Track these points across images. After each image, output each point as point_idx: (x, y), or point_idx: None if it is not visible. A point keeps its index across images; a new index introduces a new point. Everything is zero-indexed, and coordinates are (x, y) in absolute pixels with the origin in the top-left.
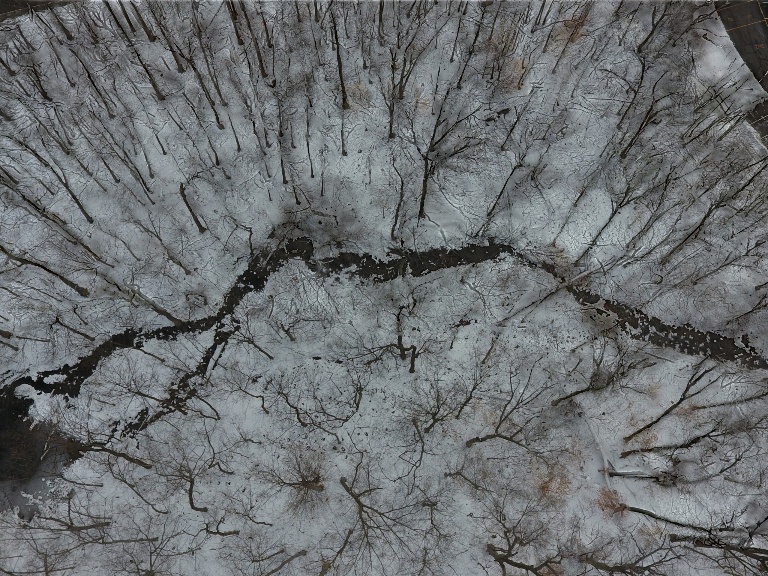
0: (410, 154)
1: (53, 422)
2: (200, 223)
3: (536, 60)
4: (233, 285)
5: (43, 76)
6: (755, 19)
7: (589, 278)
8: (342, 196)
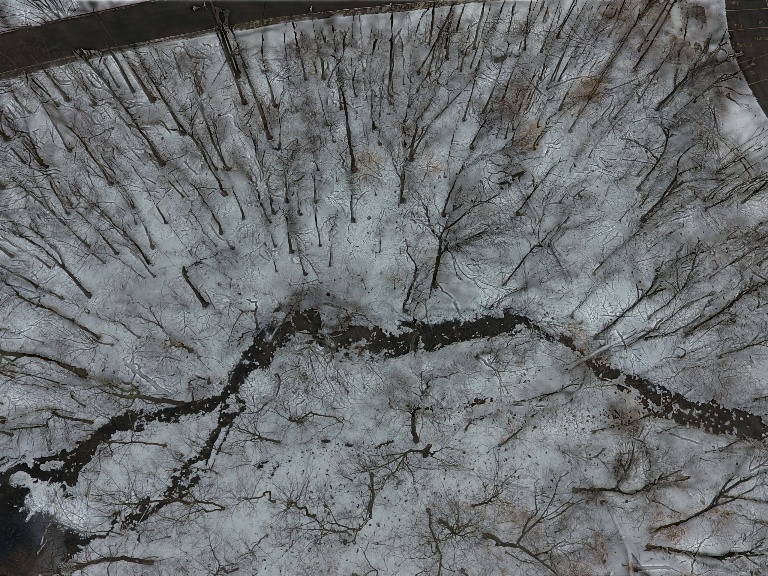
0: None
1: (50, 513)
2: (203, 298)
3: (552, 119)
4: (238, 362)
5: (39, 143)
6: None
7: (609, 352)
8: (351, 267)
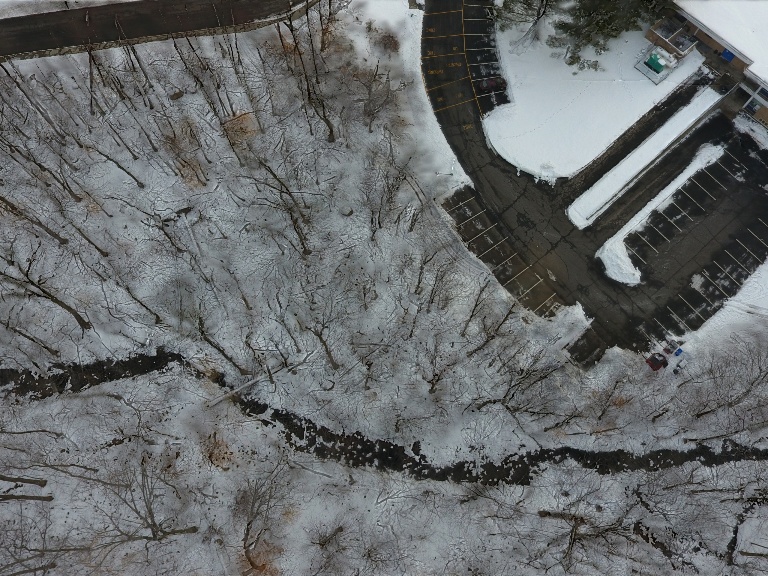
0: (82, 260)
1: None
2: None
3: (222, 154)
4: None
5: None
6: (466, 98)
7: (257, 387)
8: None
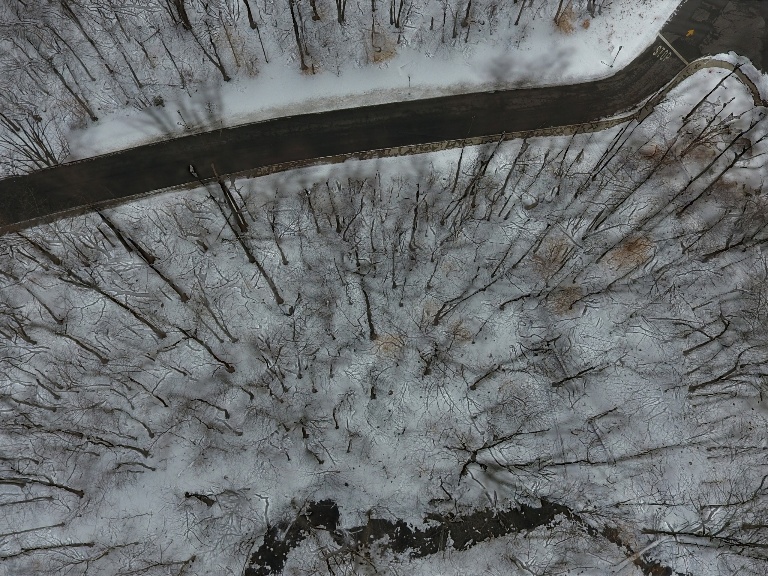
0: (448, 394)
1: None
2: None
3: (589, 274)
4: (247, 567)
5: (25, 320)
6: None
7: (659, 547)
8: (372, 454)
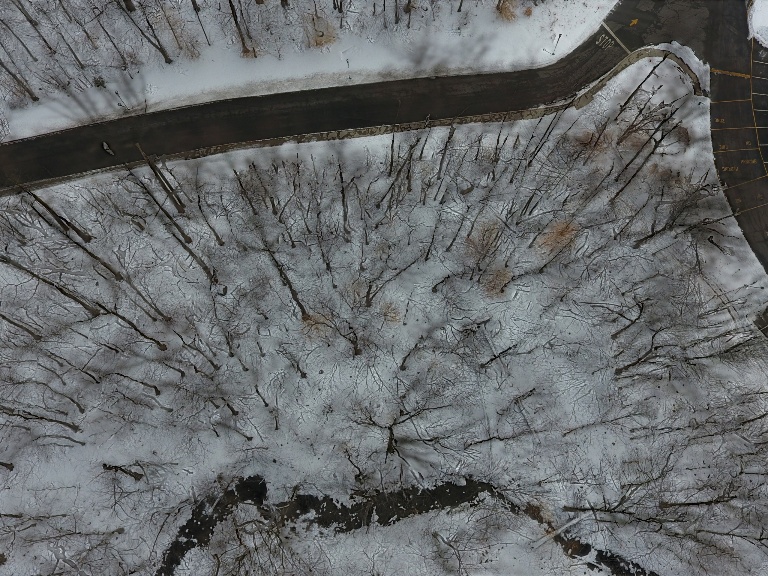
0: (378, 374)
1: None
2: (135, 471)
3: (521, 259)
4: (173, 540)
5: None
6: (765, 200)
7: (579, 525)
8: (299, 431)
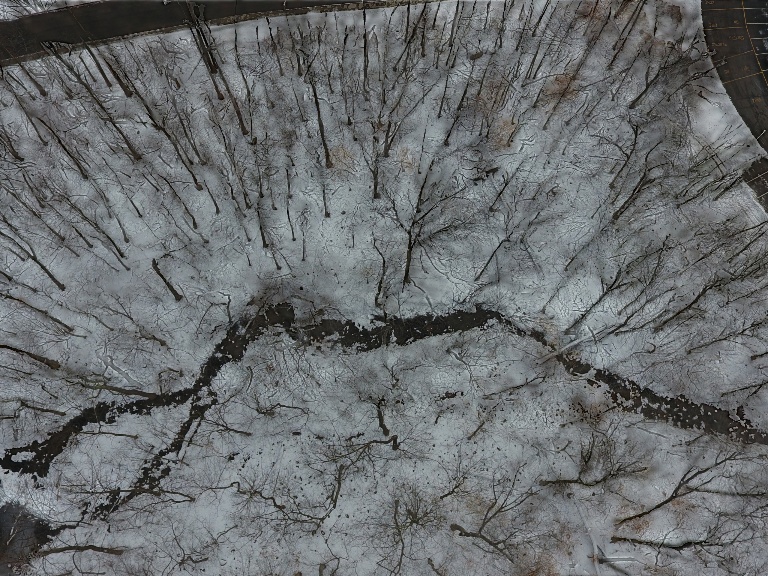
0: None
1: (20, 504)
2: (176, 291)
3: (526, 116)
4: (210, 355)
5: (14, 136)
6: (752, 71)
7: (580, 347)
8: (324, 261)
